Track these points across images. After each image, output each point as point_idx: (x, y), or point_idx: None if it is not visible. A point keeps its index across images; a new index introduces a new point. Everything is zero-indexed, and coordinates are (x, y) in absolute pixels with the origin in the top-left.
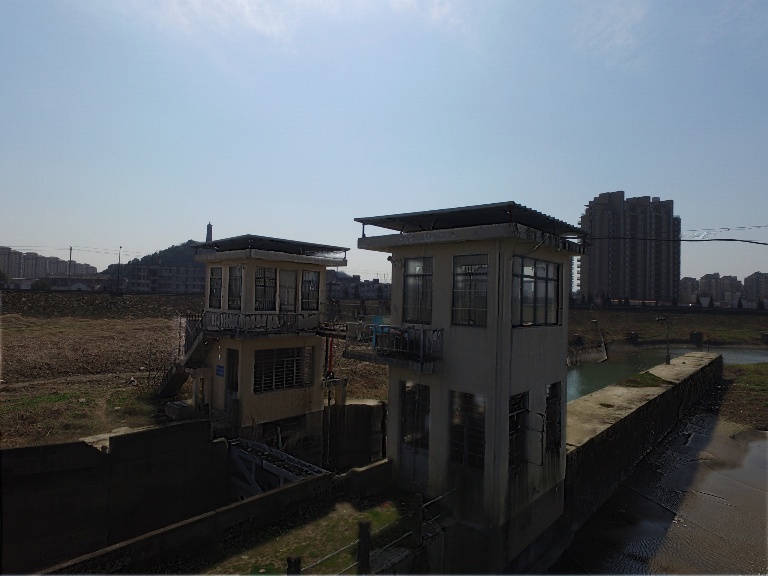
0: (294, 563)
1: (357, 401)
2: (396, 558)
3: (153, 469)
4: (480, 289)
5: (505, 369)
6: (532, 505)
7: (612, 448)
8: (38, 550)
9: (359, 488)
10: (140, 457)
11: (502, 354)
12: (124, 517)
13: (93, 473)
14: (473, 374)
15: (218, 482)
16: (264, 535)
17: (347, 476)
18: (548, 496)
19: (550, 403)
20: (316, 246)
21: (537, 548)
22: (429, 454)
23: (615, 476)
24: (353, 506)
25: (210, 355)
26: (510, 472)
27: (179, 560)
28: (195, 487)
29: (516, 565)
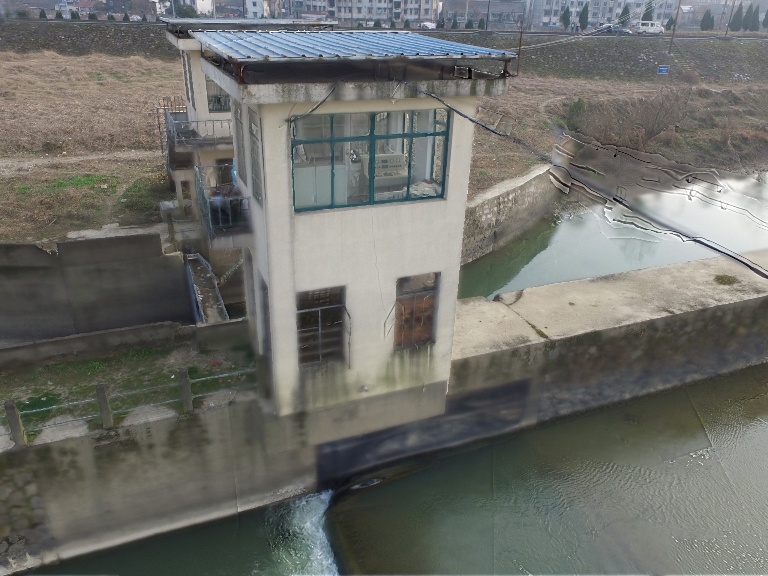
0: (6, 407)
1: None
2: (155, 418)
3: (104, 274)
4: (259, 159)
5: (279, 263)
6: (360, 401)
7: (659, 345)
8: (24, 323)
9: (199, 342)
10: (89, 263)
11: (270, 247)
12: (85, 311)
13: (49, 272)
14: (263, 259)
15: (177, 292)
16: (82, 368)
17: (195, 328)
18: (402, 395)
19: (420, 296)
20: (279, 24)
21: (427, 436)
22: (257, 327)
23: (667, 378)
24: (186, 358)
25: (193, 155)
26: (304, 368)
27: (3, 373)
28: (152, 294)
29: (377, 447)
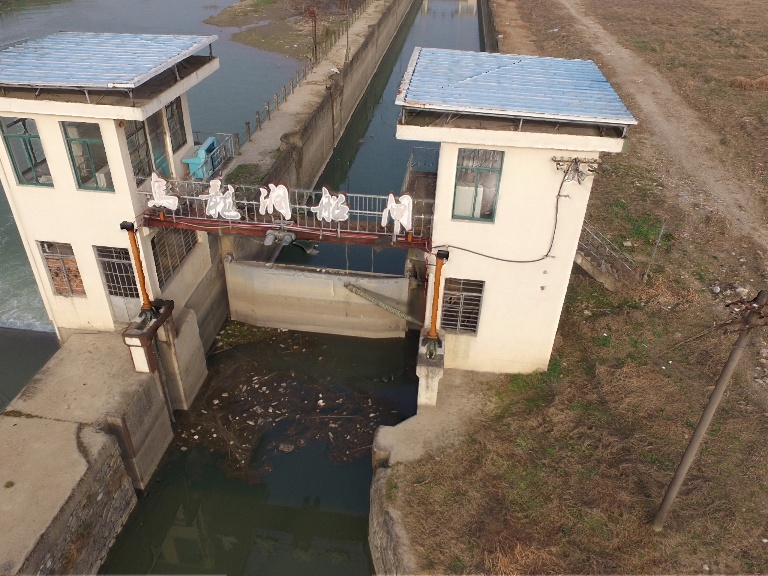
0: None
1: (422, 432)
2: None
3: None
4: None
5: None
6: None
7: None
8: None
9: None
10: None
11: None
12: None
13: None
14: None
15: None
16: None
17: None
18: None
19: None
20: None
21: None
22: None
23: None
24: None
25: None
26: None
27: None
28: None
29: None
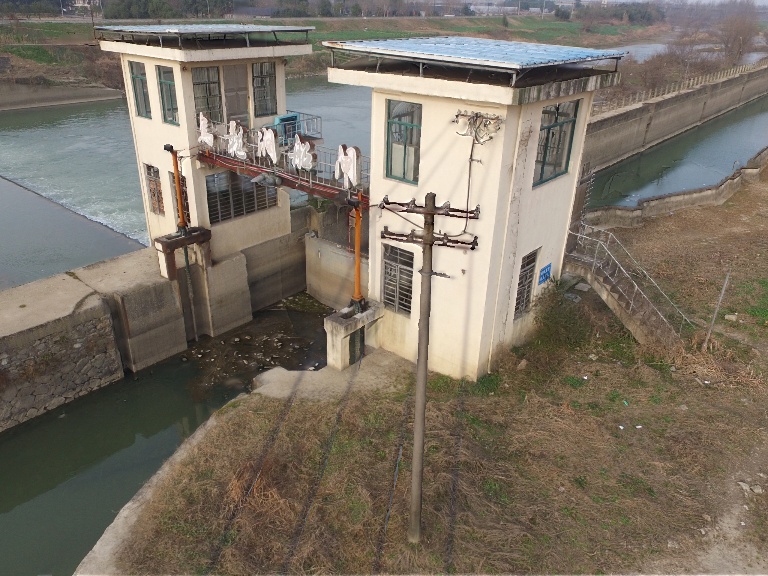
0: None
1: (305, 383)
2: None
3: None
4: None
5: None
6: None
7: None
8: None
9: None
10: None
11: None
12: None
13: None
14: None
15: None
16: None
17: None
18: None
19: None
20: None
21: None
22: None
23: None
24: None
25: None
26: None
27: None
28: None
29: None
